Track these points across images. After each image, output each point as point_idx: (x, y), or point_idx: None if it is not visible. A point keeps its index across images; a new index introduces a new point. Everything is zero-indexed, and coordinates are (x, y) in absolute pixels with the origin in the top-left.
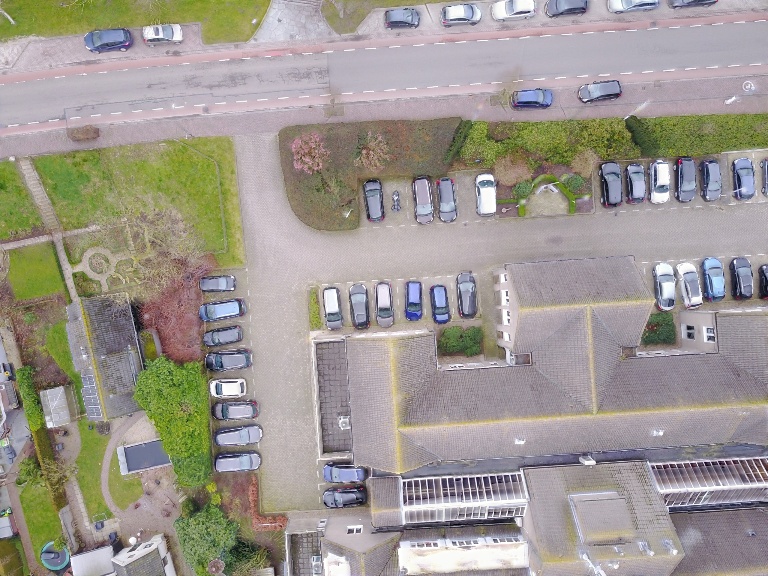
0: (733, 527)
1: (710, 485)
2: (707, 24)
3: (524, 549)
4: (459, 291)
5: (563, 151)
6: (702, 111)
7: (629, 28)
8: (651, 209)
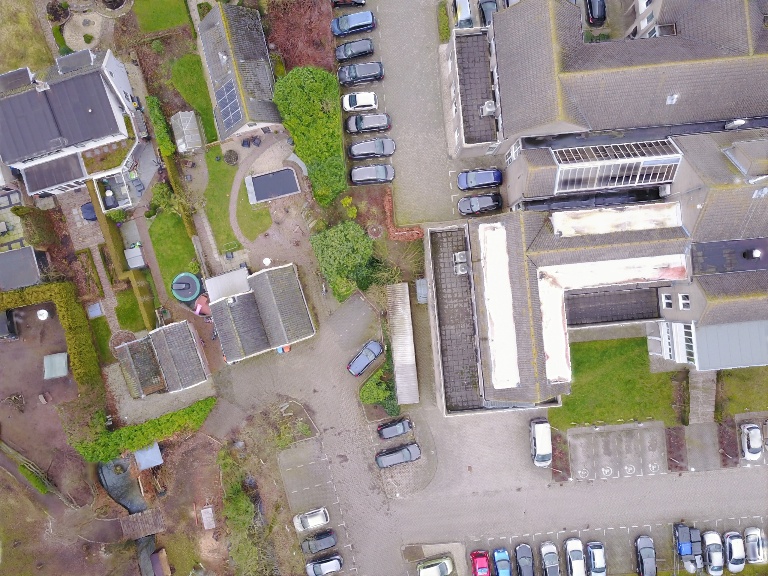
0: None
1: None
2: None
3: (676, 209)
4: None
5: None
6: None
7: None
8: None
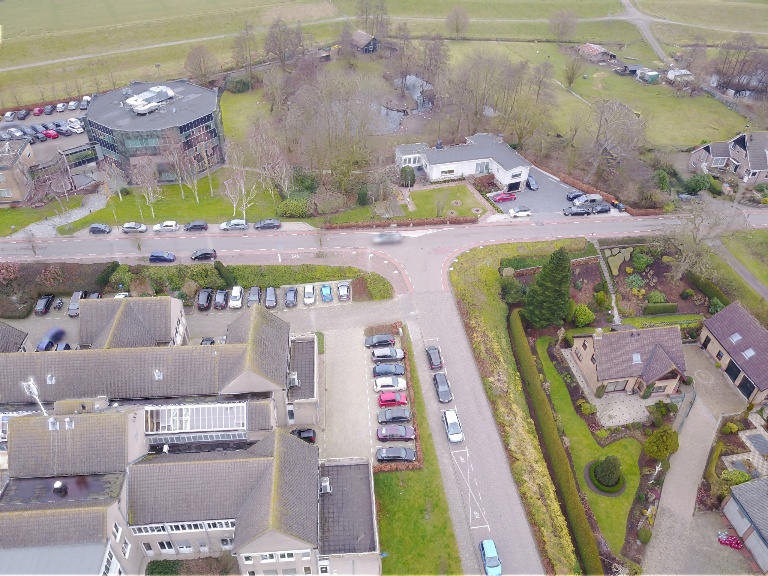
0: None
1: (187, 405)
2: (276, 235)
3: None
4: None
5: (176, 281)
6: (265, 264)
7: (231, 236)
8: (231, 313)
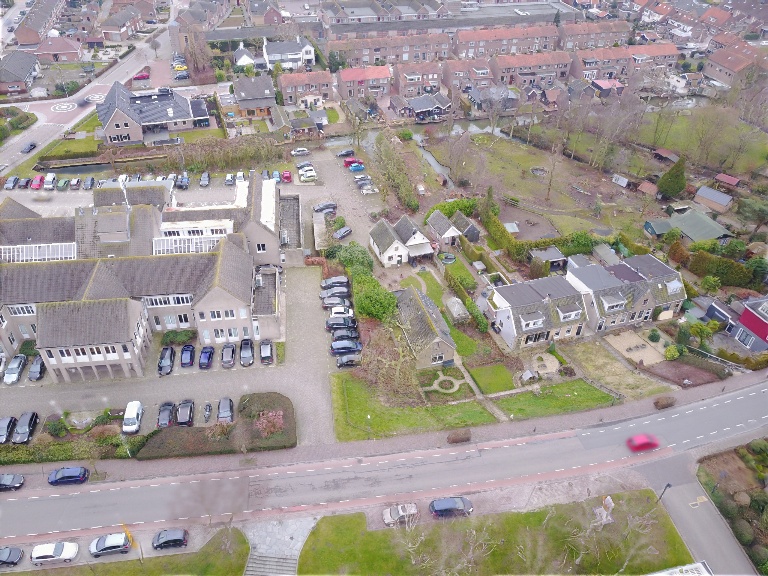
0: (39, 243)
1: (44, 246)
2: None
3: (163, 228)
4: (172, 361)
5: None
6: None
7: None
8: None
